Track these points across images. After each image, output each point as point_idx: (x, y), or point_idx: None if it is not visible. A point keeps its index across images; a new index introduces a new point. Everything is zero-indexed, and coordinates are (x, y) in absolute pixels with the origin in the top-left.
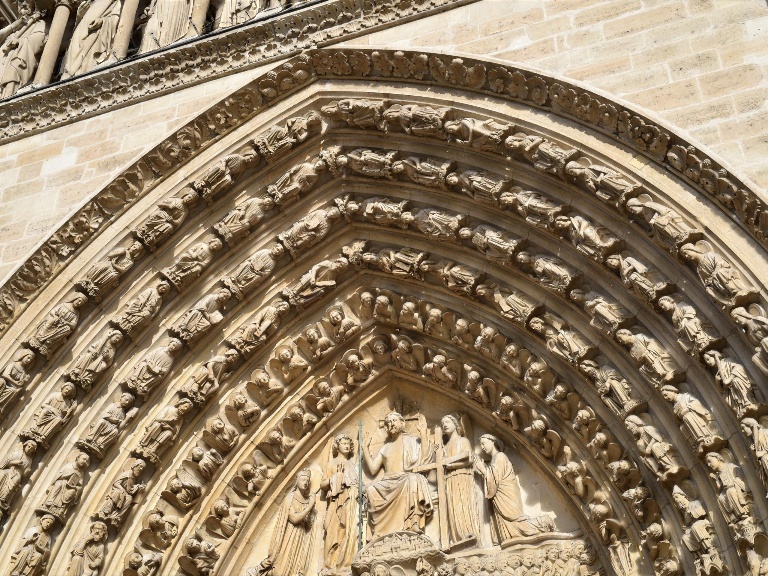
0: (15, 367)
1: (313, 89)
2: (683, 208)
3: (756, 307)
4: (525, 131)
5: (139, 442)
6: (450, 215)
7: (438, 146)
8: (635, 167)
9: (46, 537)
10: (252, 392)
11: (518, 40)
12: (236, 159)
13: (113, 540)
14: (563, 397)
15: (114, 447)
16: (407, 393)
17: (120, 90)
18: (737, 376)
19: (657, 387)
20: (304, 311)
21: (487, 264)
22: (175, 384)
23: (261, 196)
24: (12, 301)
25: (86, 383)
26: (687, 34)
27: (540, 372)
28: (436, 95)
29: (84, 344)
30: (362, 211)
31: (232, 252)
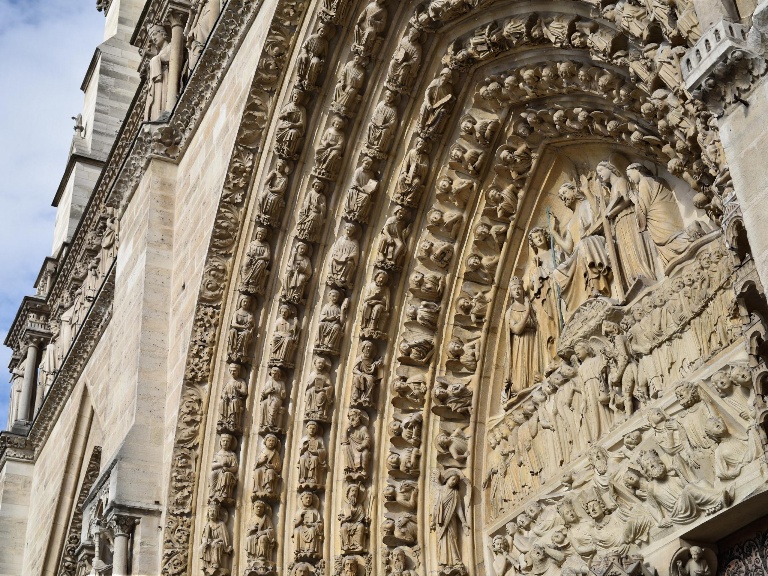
0: (239, 314)
1: None
2: None
3: None
4: None
5: None
6: None
7: None
8: None
9: (315, 441)
10: (437, 233)
11: None
12: (312, 40)
13: (376, 418)
14: (631, 99)
15: (344, 340)
16: (576, 157)
17: (233, 34)
18: (656, 6)
19: None
20: (443, 136)
21: (529, 3)
22: (370, 261)
23: None
24: (220, 261)
25: (296, 299)
26: None
27: None
28: None
29: (285, 267)
30: None
31: (358, 121)
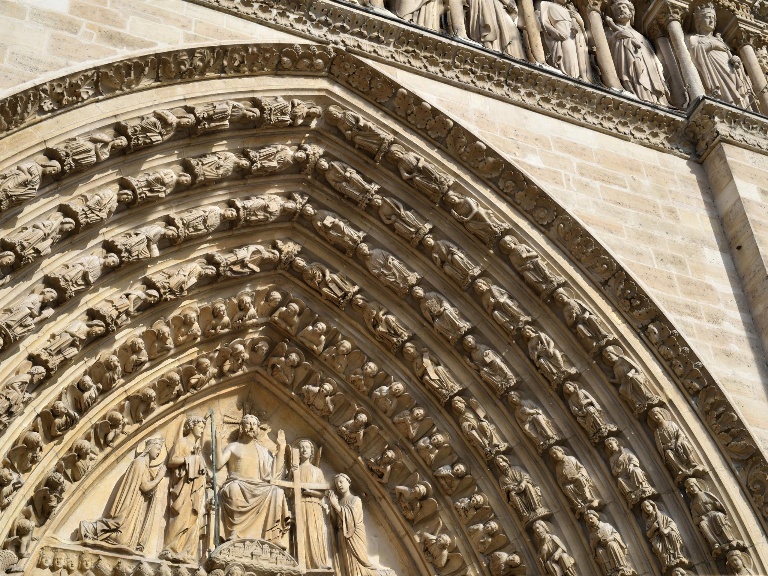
0: None
1: (322, 83)
2: (653, 375)
3: (704, 483)
4: (519, 237)
5: (42, 347)
6: (406, 268)
7: (422, 203)
8: (615, 320)
9: None
10: (145, 340)
11: (533, 157)
12: (241, 109)
13: None
14: (460, 476)
15: (18, 341)
16: (259, 399)
17: None
18: (675, 530)
19: (580, 507)
20: (219, 282)
21: (421, 327)
22: (89, 300)
23: (236, 154)
24: None
25: (26, 261)
26: (664, 232)
27: (445, 445)
28: (444, 160)
29: (31, 216)
30: (314, 218)
31: (189, 193)
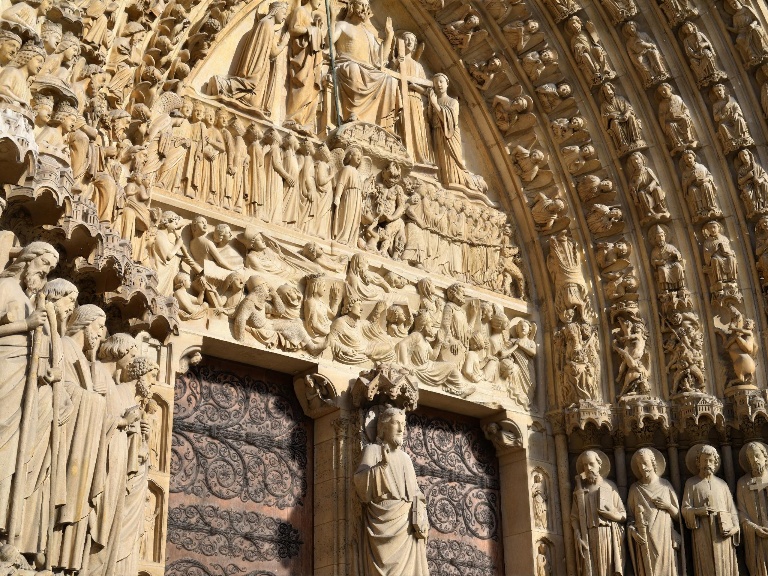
0: None
1: None
2: None
3: None
4: None
5: None
6: None
7: None
8: None
9: None
10: None
11: None
12: None
13: None
14: (564, 96)
15: None
16: None
17: None
18: (767, 181)
19: (680, 146)
20: None
21: None
22: None
23: None
24: None
25: None
26: None
27: (555, 63)
28: None
29: None
30: None
31: None
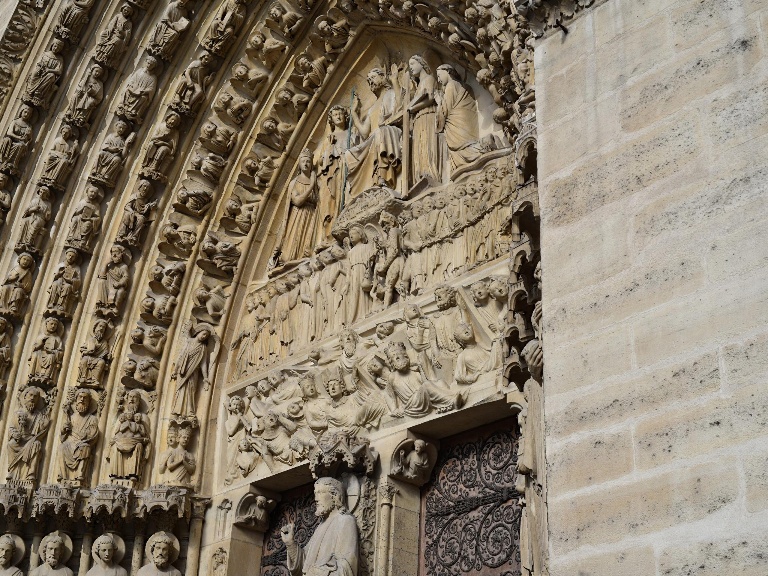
0: (17, 124)
1: None
2: None
3: None
4: None
5: None
6: None
7: None
8: None
9: (72, 269)
10: (239, 88)
11: None
12: None
13: (139, 259)
14: (457, 0)
15: (123, 174)
16: (392, 45)
17: None
18: None
19: None
20: None
21: None
22: (165, 100)
23: None
24: (7, 64)
25: (80, 122)
26: None
27: None
28: None
29: (75, 86)
30: None
31: None
